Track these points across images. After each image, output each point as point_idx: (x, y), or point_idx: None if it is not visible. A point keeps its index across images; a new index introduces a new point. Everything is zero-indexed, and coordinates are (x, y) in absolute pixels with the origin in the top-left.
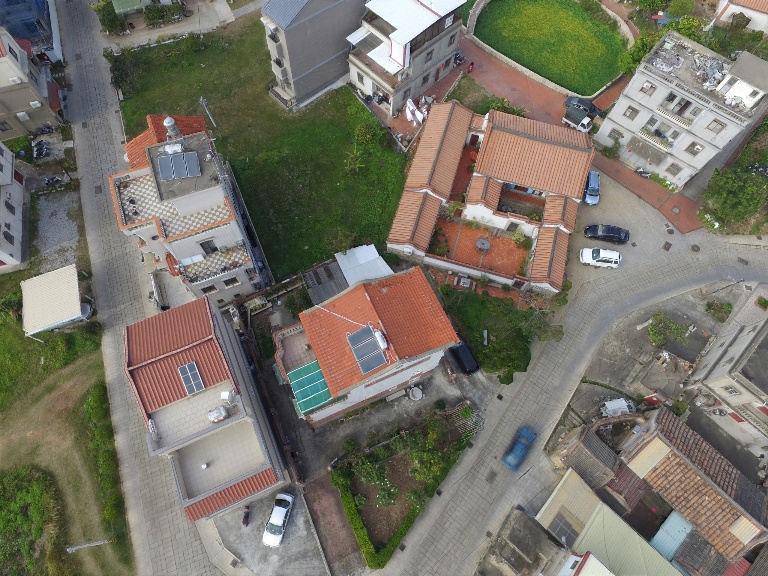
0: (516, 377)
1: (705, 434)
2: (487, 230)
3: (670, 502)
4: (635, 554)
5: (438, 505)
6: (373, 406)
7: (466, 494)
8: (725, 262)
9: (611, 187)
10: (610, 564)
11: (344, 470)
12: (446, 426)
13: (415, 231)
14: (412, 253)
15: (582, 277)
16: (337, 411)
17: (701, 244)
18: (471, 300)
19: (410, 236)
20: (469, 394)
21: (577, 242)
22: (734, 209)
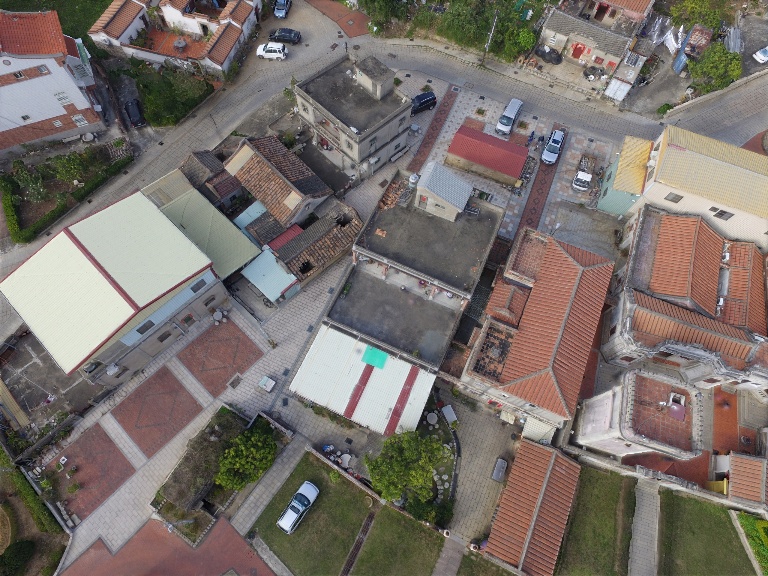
0: (179, 131)
1: (313, 163)
2: (188, 36)
3: (250, 190)
4: (206, 217)
5: (86, 209)
6: (51, 145)
7: (111, 202)
8: (377, 56)
9: (303, 7)
10: (182, 221)
11: (6, 177)
12: (94, 148)
13: (109, 23)
14: (111, 44)
15: (257, 67)
16: (0, 131)
17: (362, 45)
18: (133, 63)
19: (104, 26)
20: (136, 141)
21: (261, 44)
22: (376, 8)
